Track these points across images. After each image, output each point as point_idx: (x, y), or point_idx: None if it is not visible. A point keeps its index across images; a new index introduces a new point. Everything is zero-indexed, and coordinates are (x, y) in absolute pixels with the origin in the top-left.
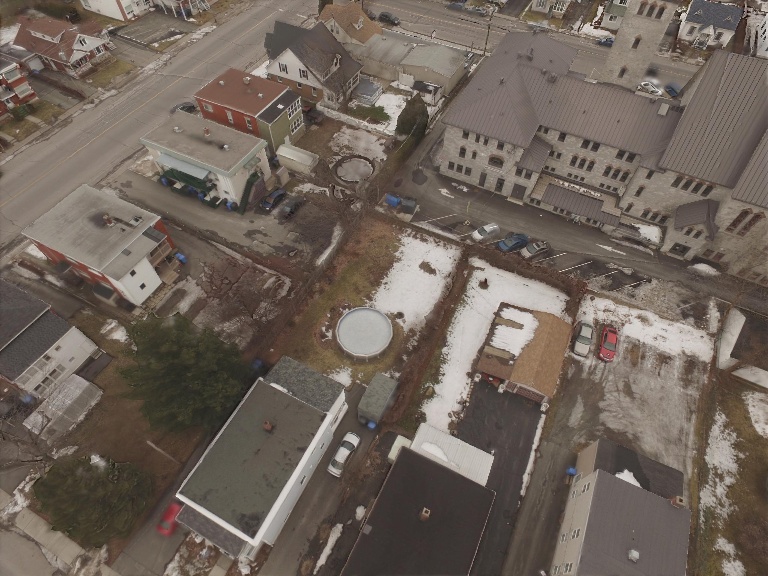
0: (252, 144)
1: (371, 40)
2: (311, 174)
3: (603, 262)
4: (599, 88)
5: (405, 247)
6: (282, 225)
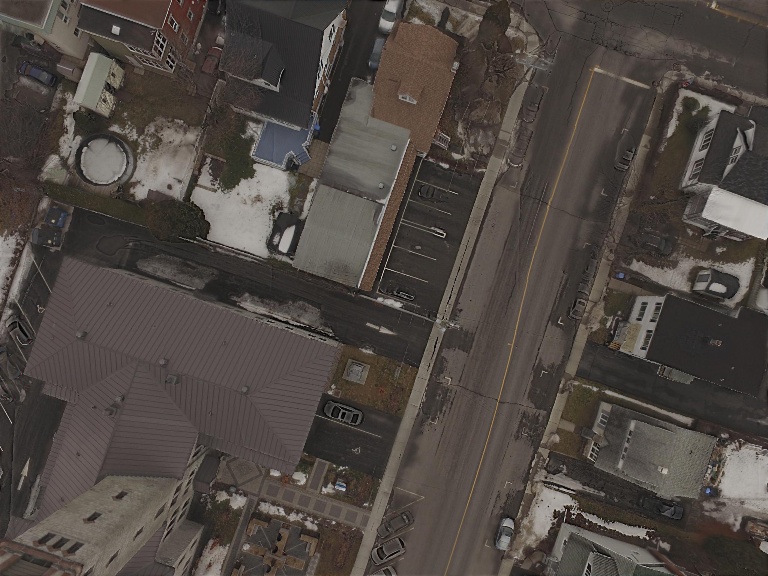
0: (29, 17)
1: (388, 127)
2: (83, 108)
3: (3, 463)
4: (94, 478)
5: (2, 242)
6: (4, 96)
